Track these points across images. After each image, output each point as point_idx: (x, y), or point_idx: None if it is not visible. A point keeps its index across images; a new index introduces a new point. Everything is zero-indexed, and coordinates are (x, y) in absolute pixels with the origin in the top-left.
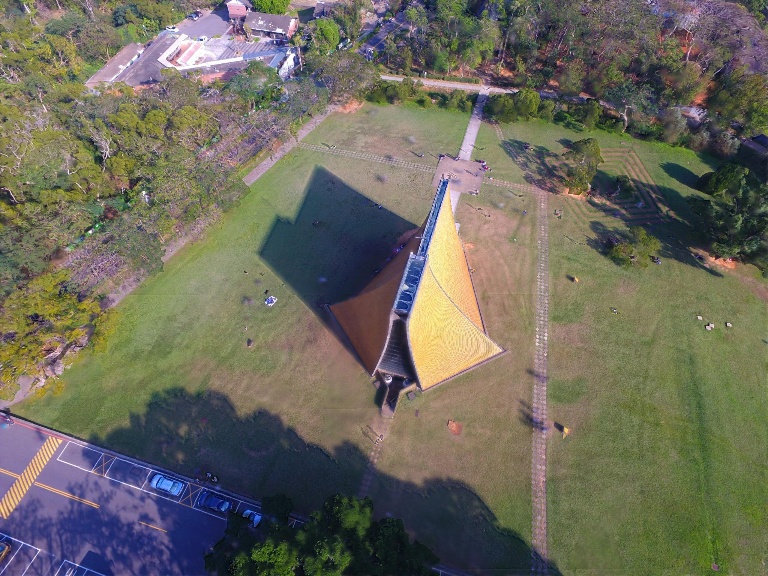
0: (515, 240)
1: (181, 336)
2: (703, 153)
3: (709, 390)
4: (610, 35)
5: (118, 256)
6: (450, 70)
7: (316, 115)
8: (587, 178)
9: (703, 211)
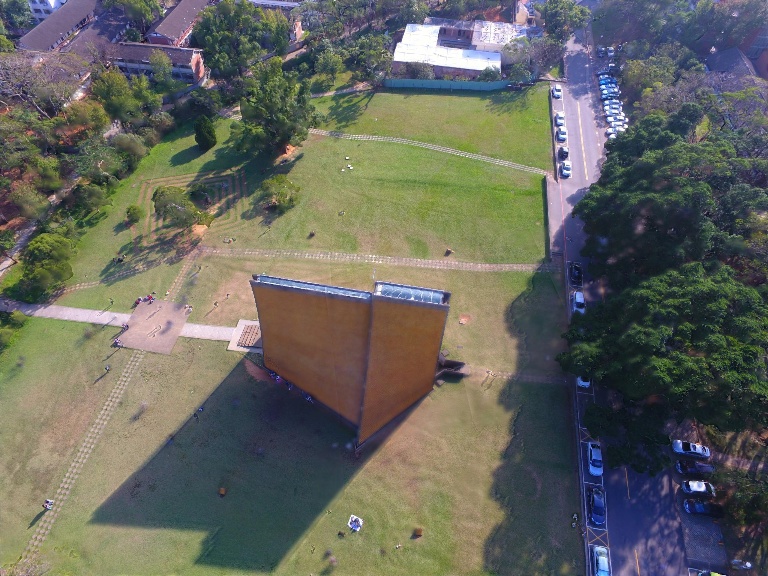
0: None
1: None
2: (162, 139)
3: (401, 176)
4: None
5: None
6: None
7: None
8: None
9: (254, 142)
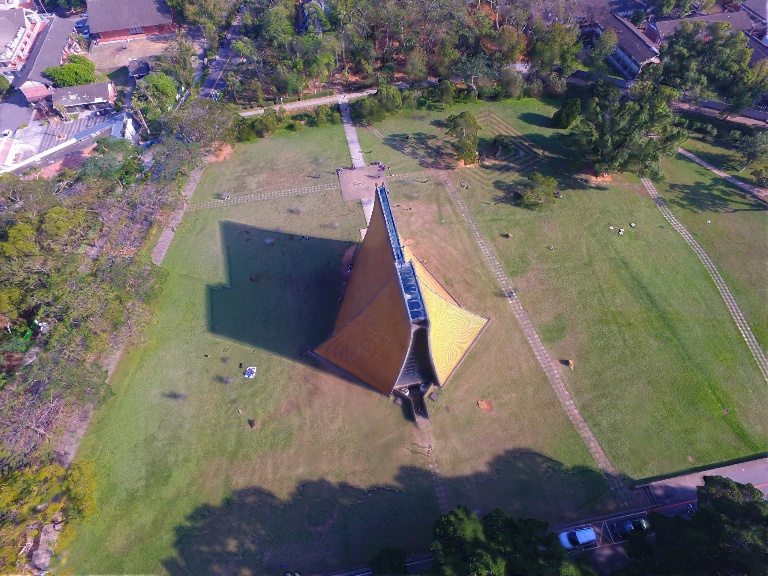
0: (443, 221)
1: (172, 453)
2: (542, 98)
3: (648, 280)
4: (432, 20)
5: (60, 400)
6: (301, 90)
7: (191, 173)
8: (473, 147)
9: (574, 143)
